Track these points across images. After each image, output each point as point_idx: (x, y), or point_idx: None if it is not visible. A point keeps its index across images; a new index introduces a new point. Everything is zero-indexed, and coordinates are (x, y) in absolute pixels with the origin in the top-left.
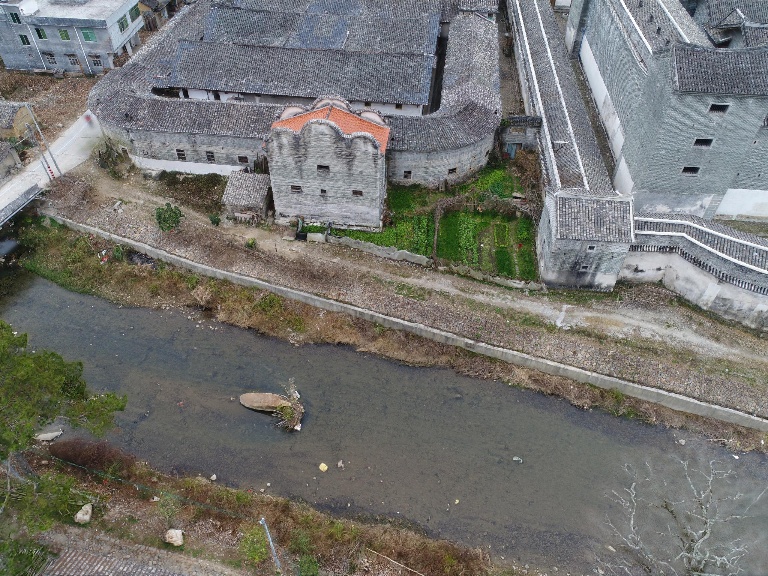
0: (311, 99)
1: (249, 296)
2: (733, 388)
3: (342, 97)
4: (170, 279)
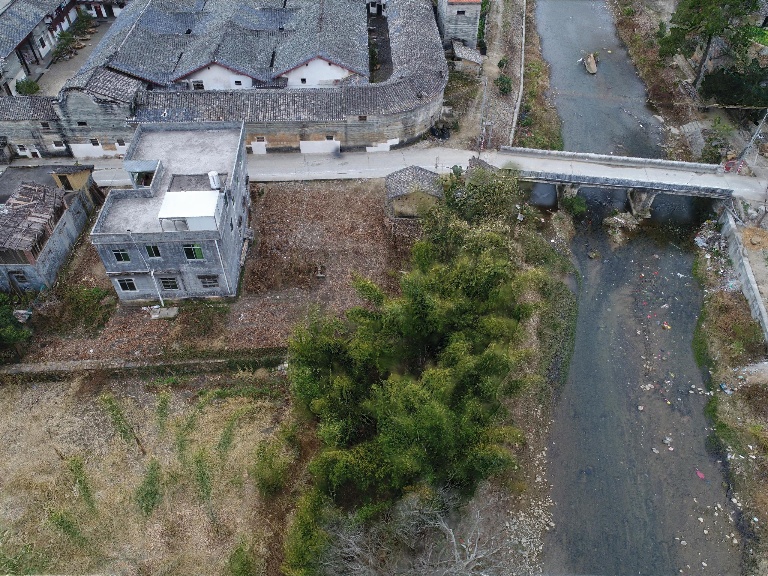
0: None
1: None
2: None
3: (366, 11)
4: None
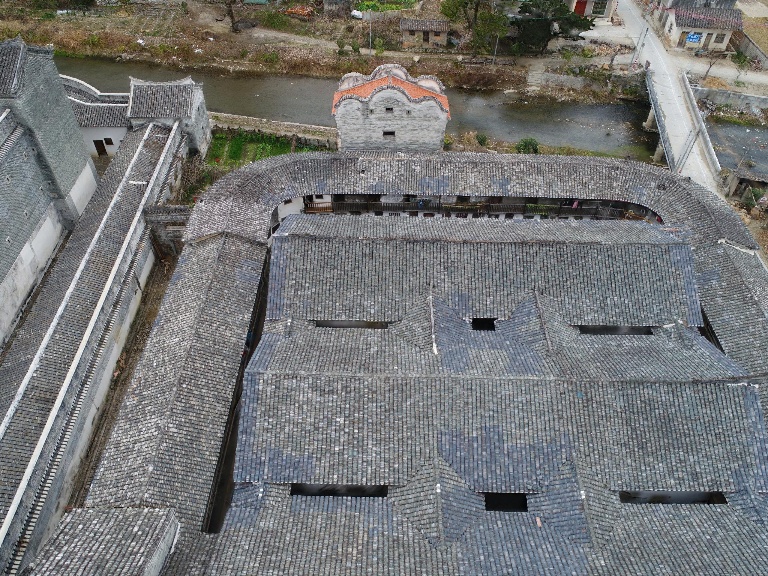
0: None
1: None
2: None
3: (403, 217)
4: None
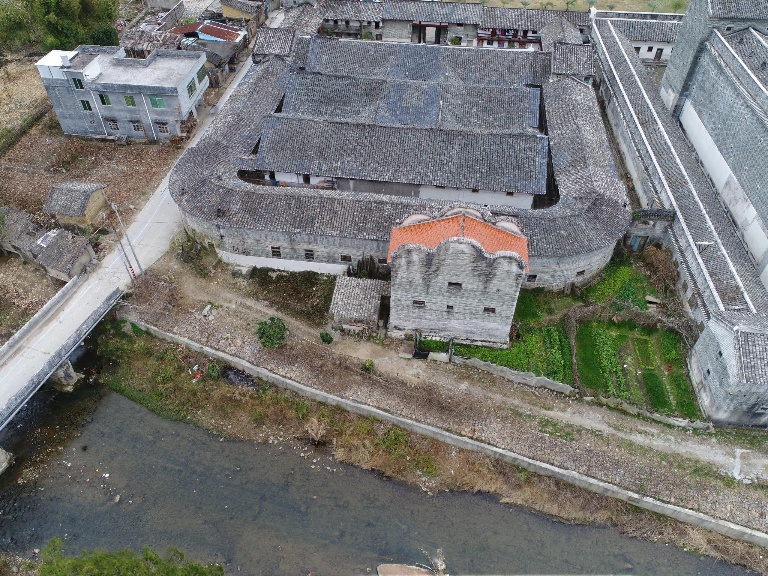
0: (413, 185)
1: (369, 429)
2: None
3: (449, 184)
4: (275, 404)
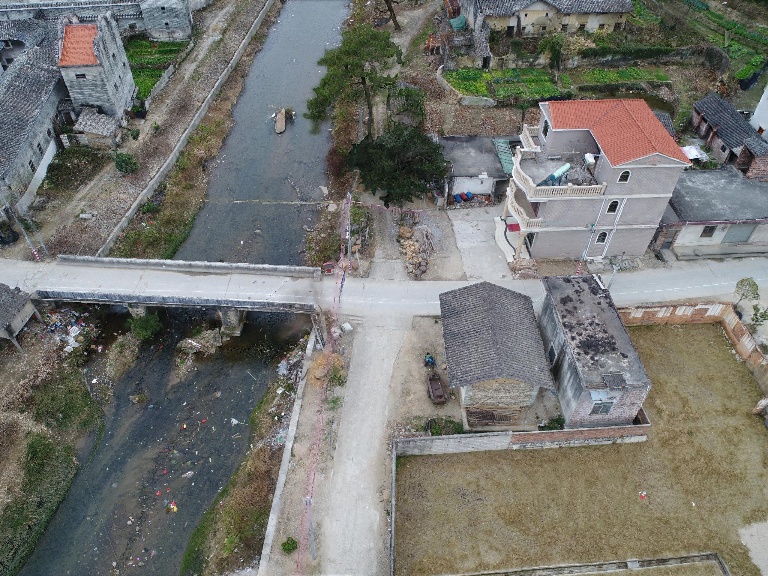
0: None
1: None
2: (251, 8)
3: None
4: None
